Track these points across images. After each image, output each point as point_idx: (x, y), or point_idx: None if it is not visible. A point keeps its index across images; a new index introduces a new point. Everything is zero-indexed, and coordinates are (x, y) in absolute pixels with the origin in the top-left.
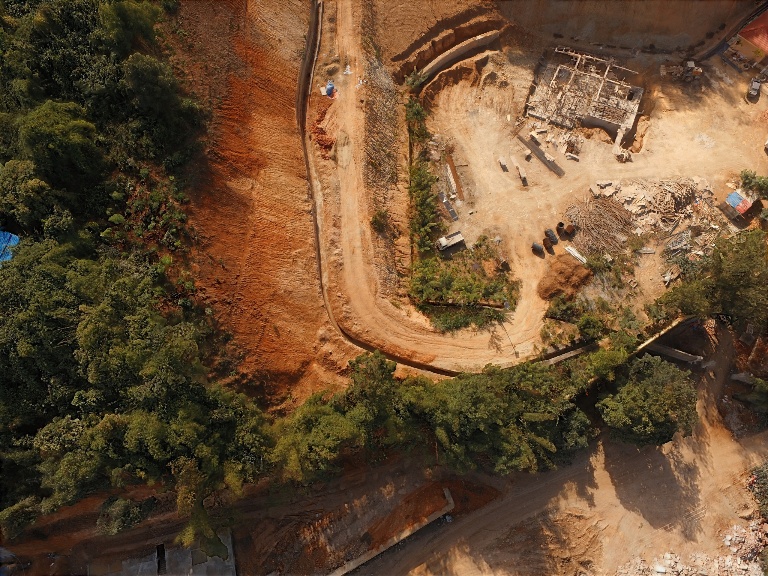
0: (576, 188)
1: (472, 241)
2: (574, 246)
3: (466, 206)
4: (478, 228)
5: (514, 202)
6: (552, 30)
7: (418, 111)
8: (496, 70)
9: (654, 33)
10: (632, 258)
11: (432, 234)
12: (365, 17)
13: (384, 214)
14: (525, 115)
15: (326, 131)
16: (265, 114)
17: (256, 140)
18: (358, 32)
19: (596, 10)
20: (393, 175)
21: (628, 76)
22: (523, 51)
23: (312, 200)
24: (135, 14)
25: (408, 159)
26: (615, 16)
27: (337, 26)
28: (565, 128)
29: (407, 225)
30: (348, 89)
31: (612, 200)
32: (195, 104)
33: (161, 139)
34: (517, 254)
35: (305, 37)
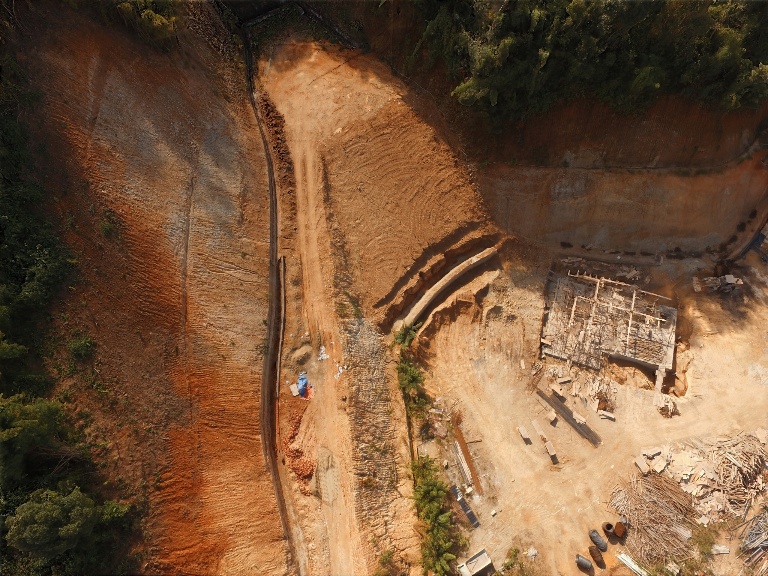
0: (618, 461)
1: (500, 558)
2: (628, 553)
3: (487, 503)
4: (506, 536)
5: (545, 490)
6: (558, 239)
7: (413, 377)
8: (500, 301)
9: (679, 236)
10: (703, 563)
11: (449, 552)
12: (337, 269)
13: (388, 559)
14: (541, 355)
15: (303, 450)
16: (221, 465)
17: (211, 514)
18: (330, 295)
19: (608, 217)
20: (392, 479)
21: (654, 287)
22: (527, 266)
23: (293, 565)
24: (22, 431)
25: (408, 442)
26: (631, 222)
27: (304, 289)
28: (591, 369)
29: (417, 548)
30: (325, 382)
31: (665, 478)
32: (122, 511)
33: (77, 572)
34: (559, 573)
35: (265, 322)
